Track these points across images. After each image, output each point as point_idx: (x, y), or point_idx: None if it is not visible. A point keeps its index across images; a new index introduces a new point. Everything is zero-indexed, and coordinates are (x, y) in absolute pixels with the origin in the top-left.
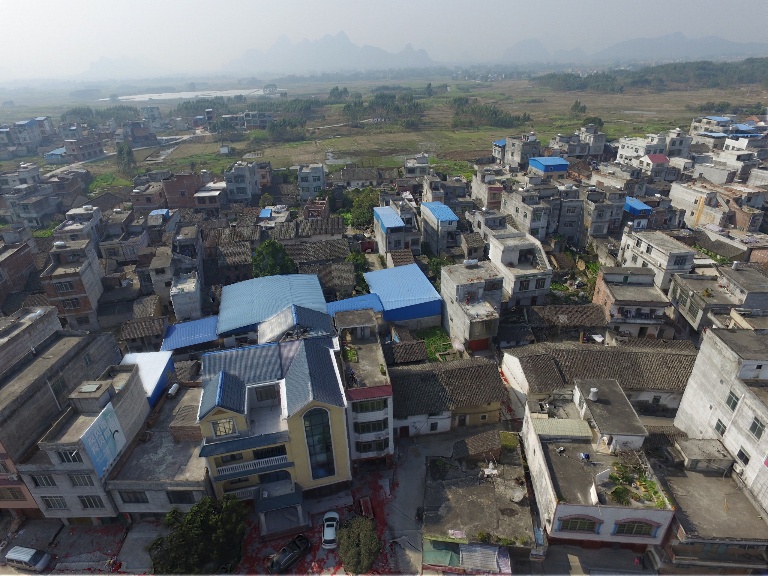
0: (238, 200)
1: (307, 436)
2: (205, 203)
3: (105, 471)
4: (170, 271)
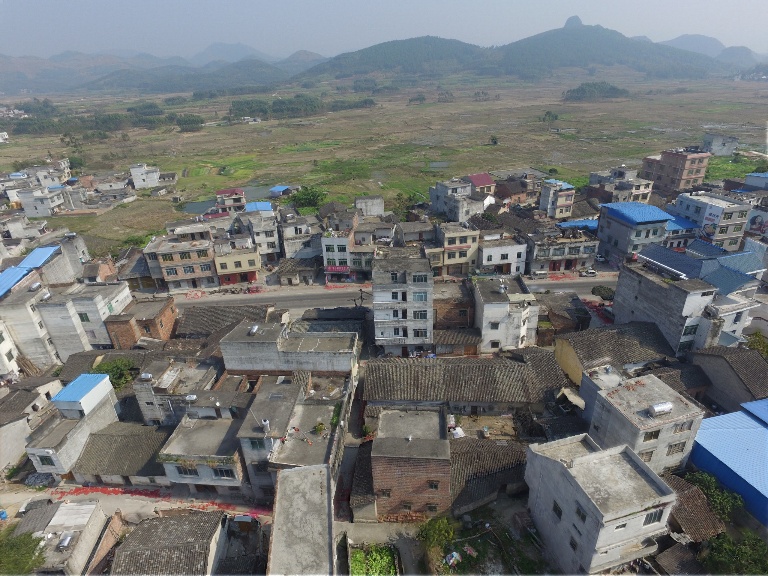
0: None
1: None
2: None
3: None
4: None
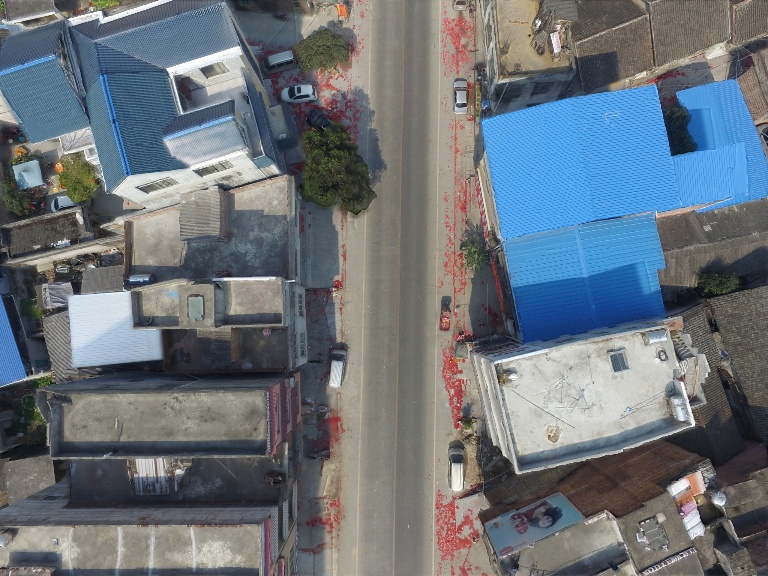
0: None
1: (244, 53)
2: None
3: None
4: None
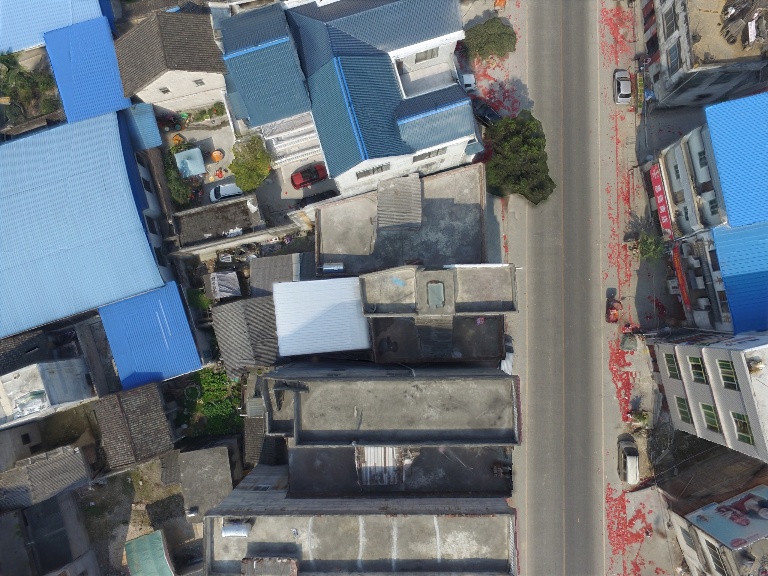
0: None
1: None
2: None
3: None
4: None
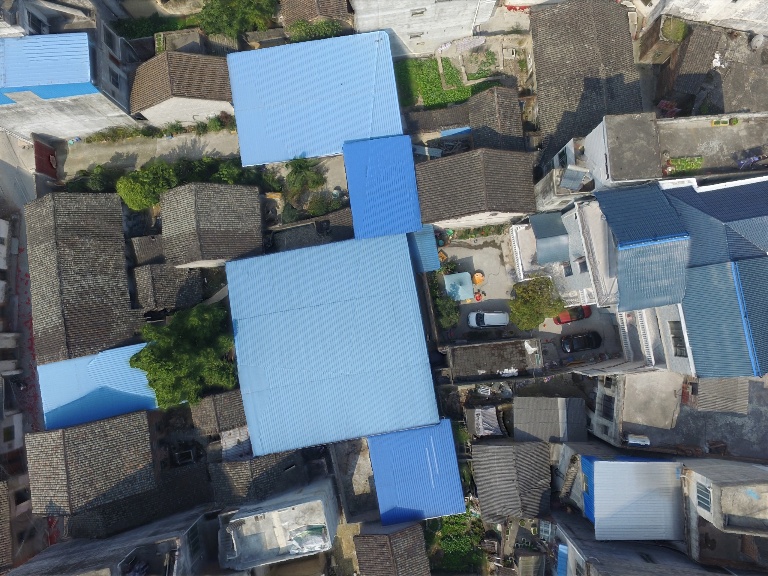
0: None
1: None
2: None
3: None
4: None
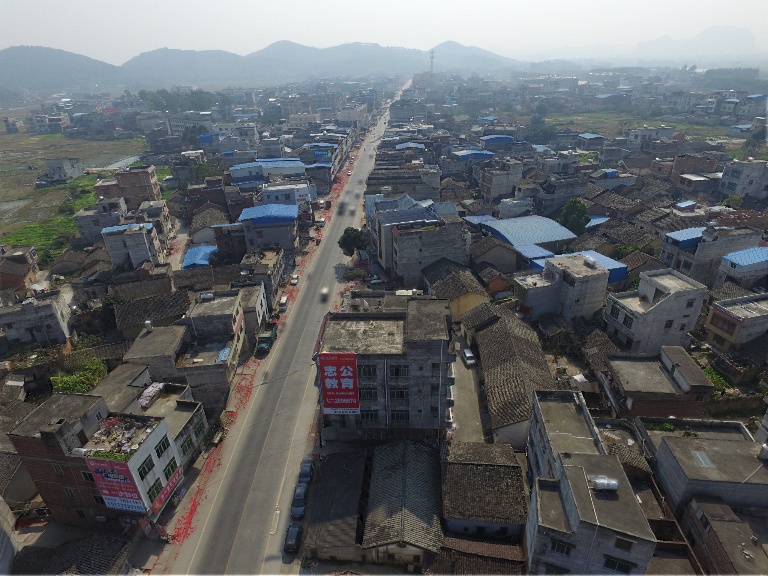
0: (727, 195)
1: None
2: (684, 184)
3: (370, 214)
4: (523, 192)
